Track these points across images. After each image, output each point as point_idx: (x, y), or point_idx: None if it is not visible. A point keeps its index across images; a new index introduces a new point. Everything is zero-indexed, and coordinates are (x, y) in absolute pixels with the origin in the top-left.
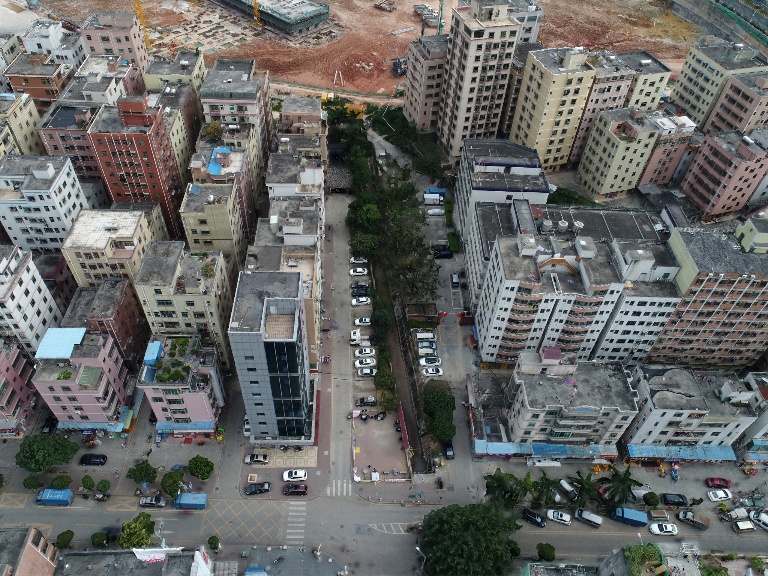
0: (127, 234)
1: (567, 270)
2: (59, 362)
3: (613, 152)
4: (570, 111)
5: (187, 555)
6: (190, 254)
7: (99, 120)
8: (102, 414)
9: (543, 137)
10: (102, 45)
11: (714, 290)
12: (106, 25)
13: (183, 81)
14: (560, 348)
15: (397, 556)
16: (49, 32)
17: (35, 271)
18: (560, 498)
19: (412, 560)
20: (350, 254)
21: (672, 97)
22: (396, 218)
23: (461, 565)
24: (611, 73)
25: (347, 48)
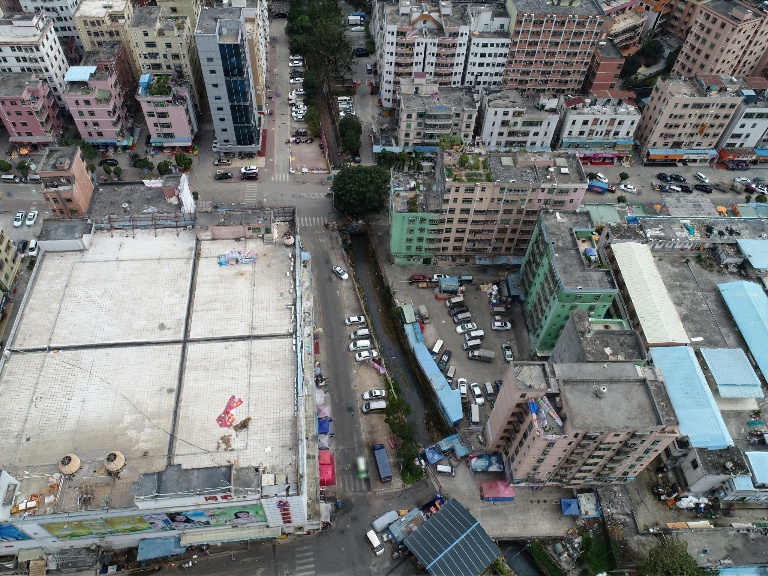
0: (119, 10)
1: (434, 26)
2: (80, 87)
3: None
4: None
5: (177, 176)
6: (166, 18)
7: None
8: (112, 130)
9: None
10: None
11: (531, 30)
12: None
13: None
14: None
15: (319, 208)
16: None
17: (55, 36)
18: None
19: (329, 209)
20: (289, 54)
21: None
22: (323, 24)
23: (354, 188)
24: None
25: None
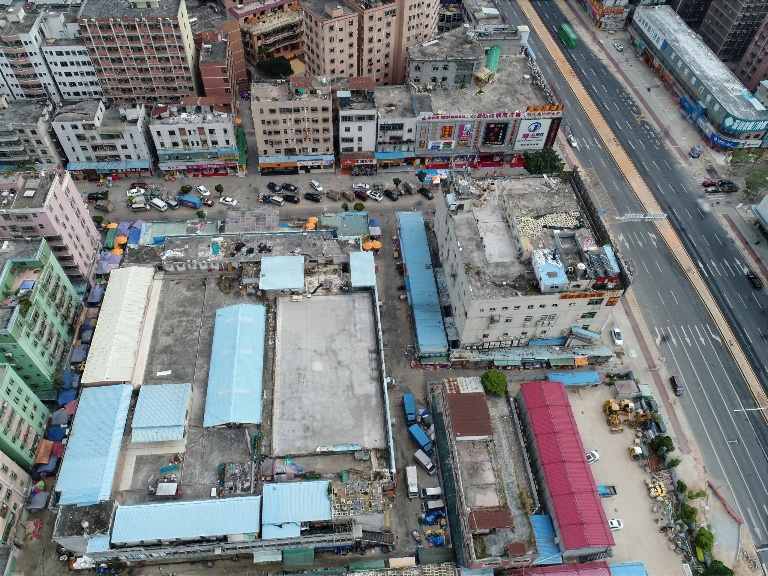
0: None
1: None
2: None
3: None
4: None
5: None
6: None
7: None
8: None
9: None
10: None
11: (102, 35)
12: None
13: None
14: None
15: None
16: None
17: None
18: None
19: None
20: None
21: None
22: None
23: None
24: None
25: None
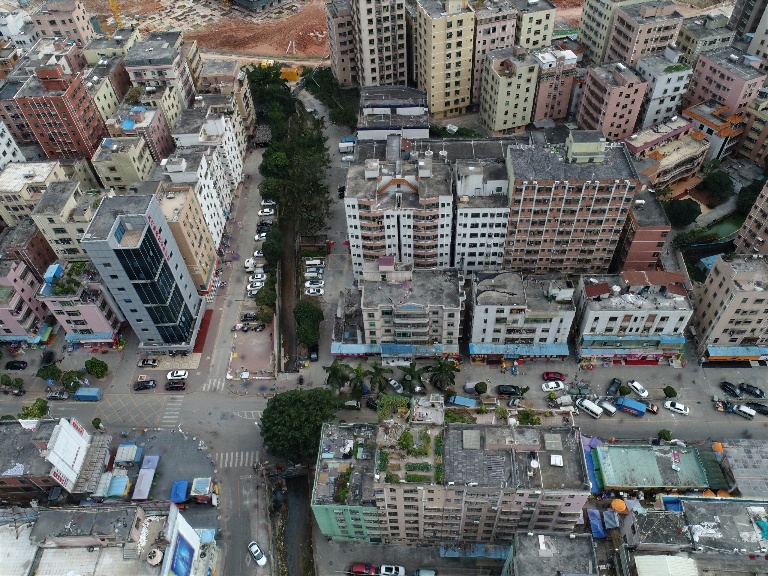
0: (41, 180)
1: (412, 190)
2: None
3: (497, 88)
4: (458, 53)
5: (55, 421)
6: (87, 192)
7: (26, 88)
8: (20, 327)
9: (438, 80)
10: (51, 28)
11: (536, 198)
12: (53, 10)
13: (117, 54)
14: (418, 263)
15: (252, 436)
16: (7, 21)
17: None
18: (404, 390)
19: None
20: None
21: (579, 36)
22: (300, 163)
23: (282, 432)
24: (492, 14)
25: (305, 20)
